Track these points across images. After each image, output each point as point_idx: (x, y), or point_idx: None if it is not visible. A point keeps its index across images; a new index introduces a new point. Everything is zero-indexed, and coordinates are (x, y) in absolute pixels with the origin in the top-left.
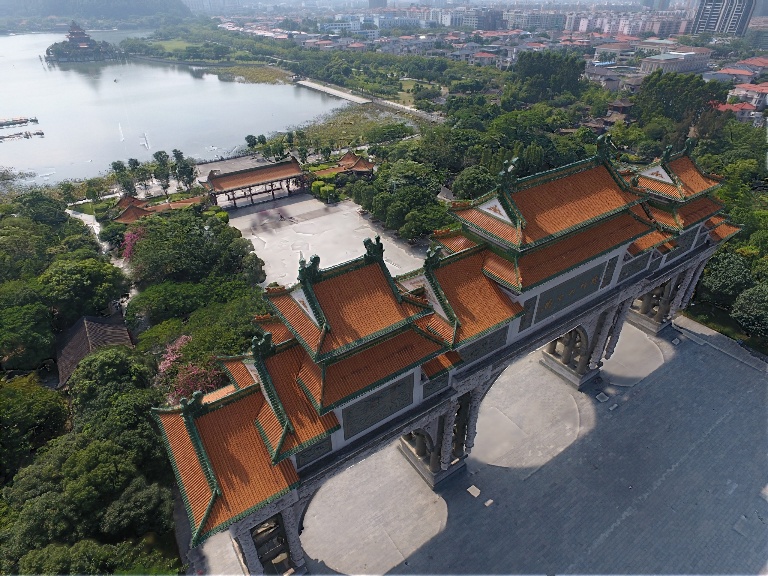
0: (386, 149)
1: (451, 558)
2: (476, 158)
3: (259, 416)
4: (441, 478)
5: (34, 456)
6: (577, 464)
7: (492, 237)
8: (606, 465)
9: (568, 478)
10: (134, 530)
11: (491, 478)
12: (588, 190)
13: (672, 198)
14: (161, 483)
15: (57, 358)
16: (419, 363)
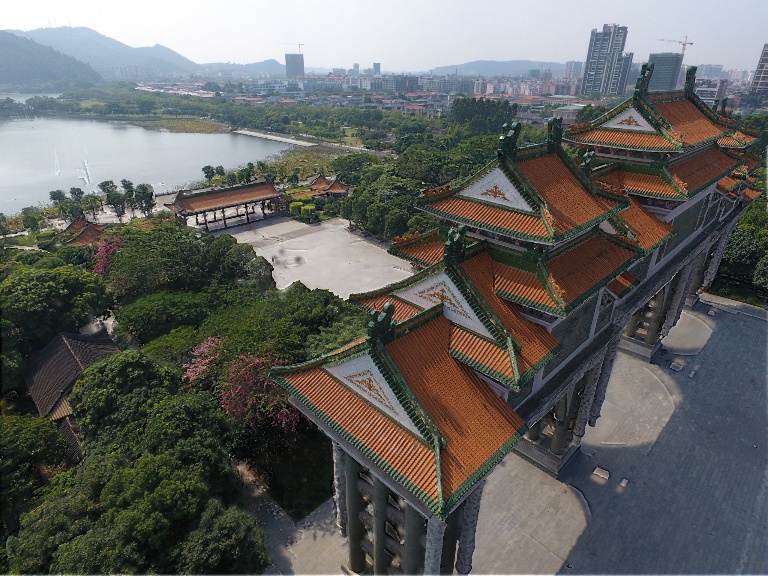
0: (357, 174)
1: (616, 550)
2: (452, 176)
3: (453, 344)
4: (563, 463)
5: (30, 502)
6: (690, 431)
7: (635, 148)
8: (719, 428)
9: (690, 446)
10: (224, 571)
11: (612, 457)
12: (691, 117)
13: (731, 146)
14: None
15: (27, 387)
16: (622, 269)
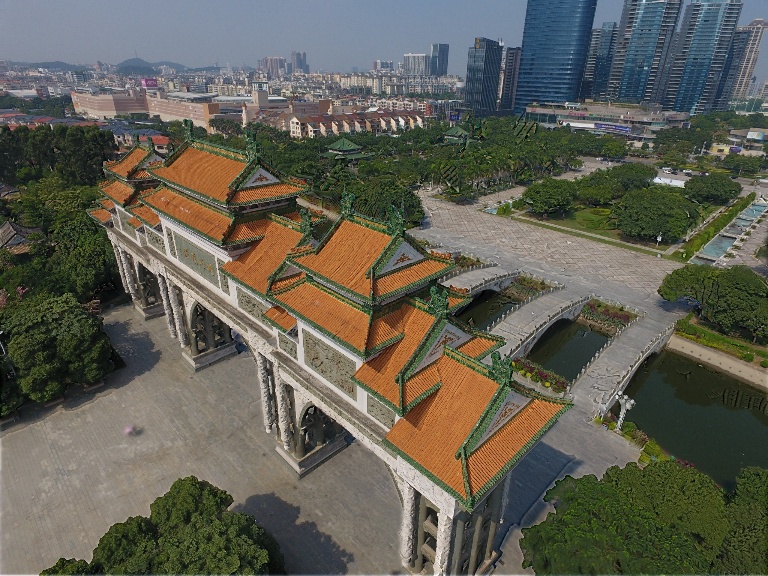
0: None
1: None
2: None
3: None
4: None
5: None
6: None
7: (283, 197)
8: None
9: None
10: None
11: None
12: None
13: None
14: None
15: None
16: None
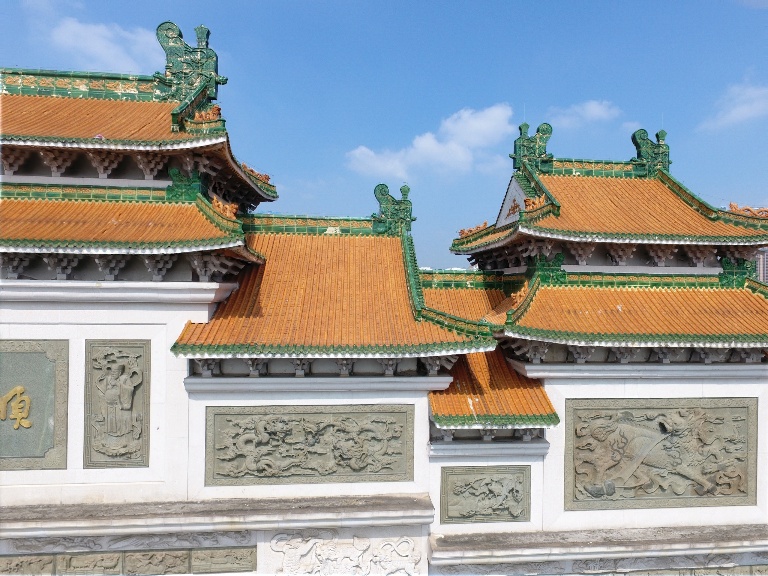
0: None
1: None
2: None
3: None
4: None
5: None
6: None
7: (260, 188)
8: None
9: None
10: None
11: None
12: None
13: None
14: None
15: None
16: None
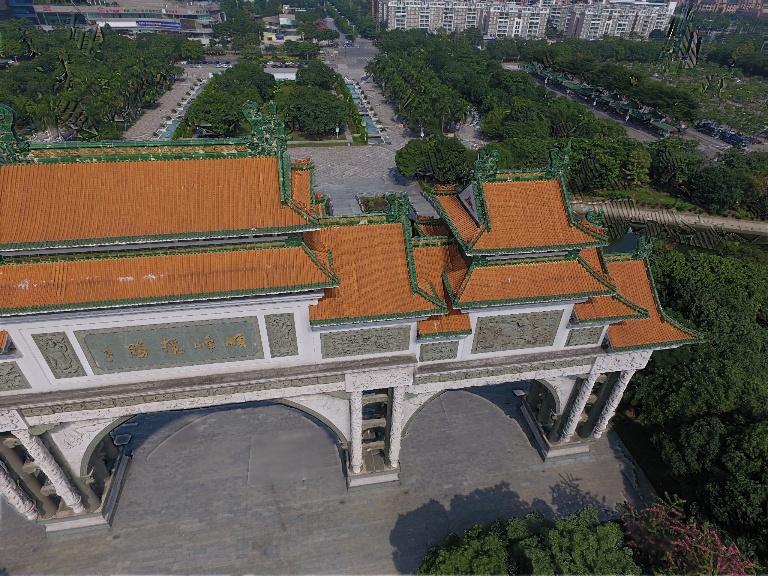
0: None
1: None
2: None
3: None
4: None
5: None
6: None
7: None
8: None
9: None
10: None
11: None
12: None
13: None
14: (691, 485)
15: None
16: None
